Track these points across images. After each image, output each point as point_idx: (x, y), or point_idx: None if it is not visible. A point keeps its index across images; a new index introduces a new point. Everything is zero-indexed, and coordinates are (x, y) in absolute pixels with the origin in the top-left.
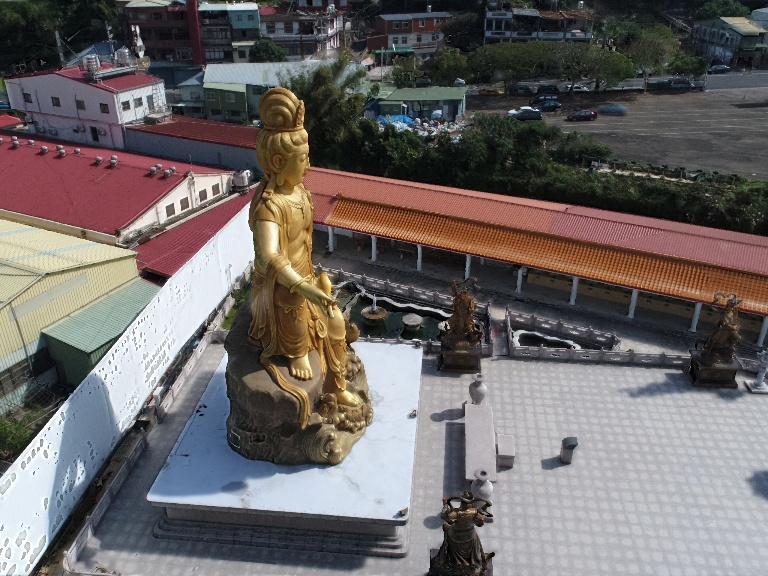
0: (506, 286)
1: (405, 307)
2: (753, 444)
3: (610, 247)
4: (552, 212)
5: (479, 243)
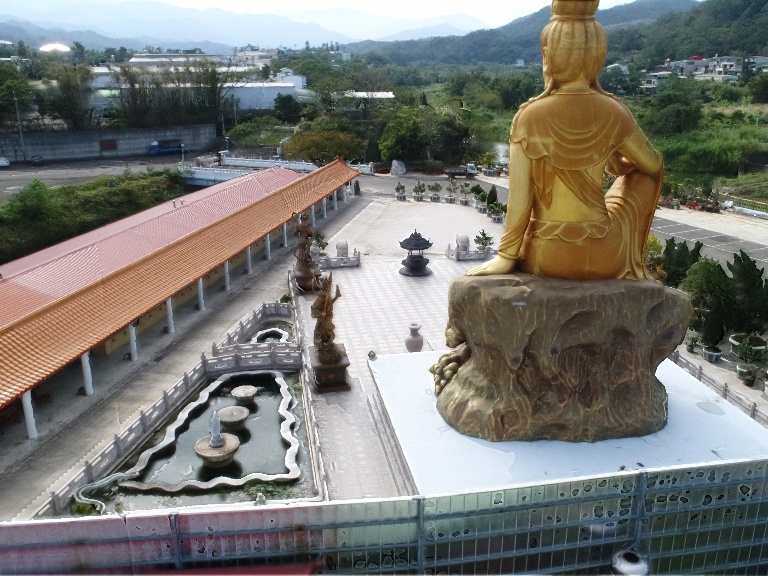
0: (118, 366)
1: None
2: (391, 282)
3: (156, 254)
4: (3, 284)
5: (89, 325)
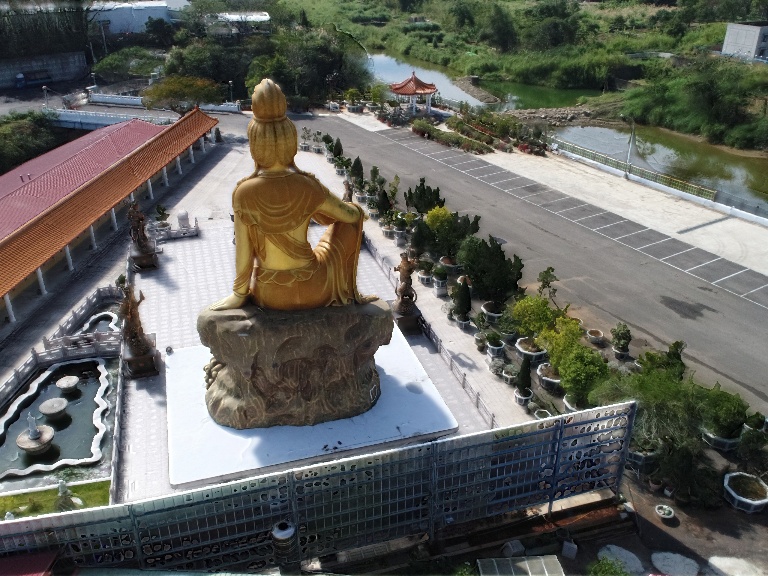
0: None
1: (4, 427)
2: None
3: None
4: None
5: None
